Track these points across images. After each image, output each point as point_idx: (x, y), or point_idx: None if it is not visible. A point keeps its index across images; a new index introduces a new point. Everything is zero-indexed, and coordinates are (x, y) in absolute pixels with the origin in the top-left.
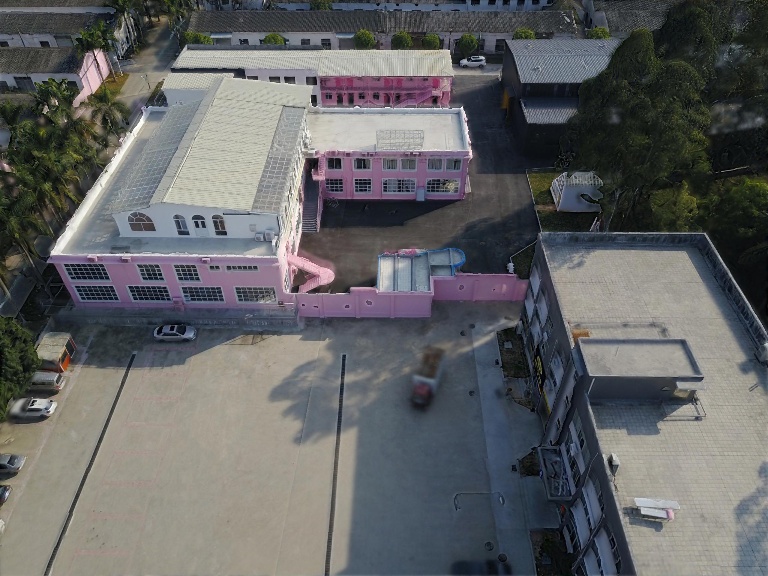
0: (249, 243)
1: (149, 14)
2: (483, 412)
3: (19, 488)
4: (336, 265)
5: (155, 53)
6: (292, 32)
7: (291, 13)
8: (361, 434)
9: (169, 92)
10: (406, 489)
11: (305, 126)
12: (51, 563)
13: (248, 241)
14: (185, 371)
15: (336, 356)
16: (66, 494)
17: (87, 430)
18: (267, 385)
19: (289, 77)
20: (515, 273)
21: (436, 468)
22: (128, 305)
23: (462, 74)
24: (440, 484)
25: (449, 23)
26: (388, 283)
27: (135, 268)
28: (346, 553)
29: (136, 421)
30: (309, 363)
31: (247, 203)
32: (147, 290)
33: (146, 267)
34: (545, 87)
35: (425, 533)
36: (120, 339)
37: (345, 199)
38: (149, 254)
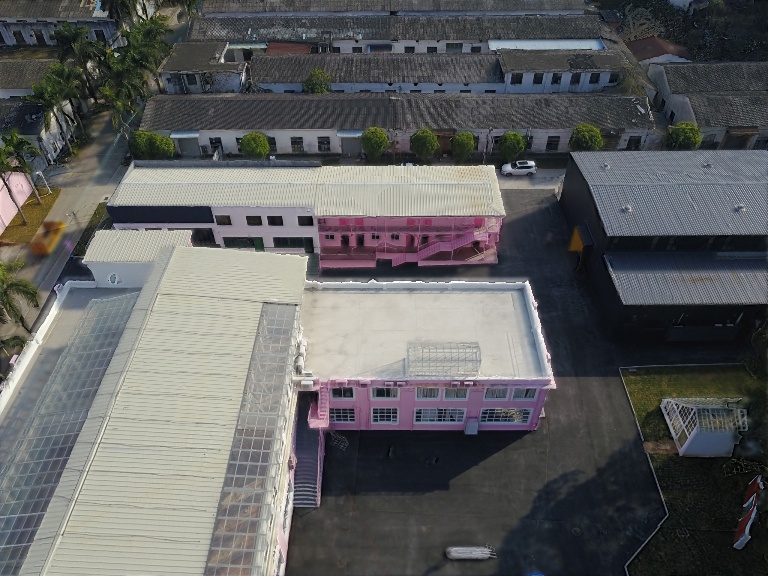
0: None
1: (94, 96)
2: None
3: None
4: None
5: (99, 154)
6: (279, 129)
7: (277, 101)
8: None
9: (94, 265)
10: None
11: (297, 331)
12: None
13: None
14: None
15: None
16: None
17: None
18: None
19: (274, 216)
20: None
21: None
22: None
23: (506, 187)
24: None
25: (486, 115)
26: None
27: None
28: None
29: None
30: None
31: (195, 566)
32: None
33: None
34: (640, 240)
35: None
36: None
37: (358, 430)
38: None
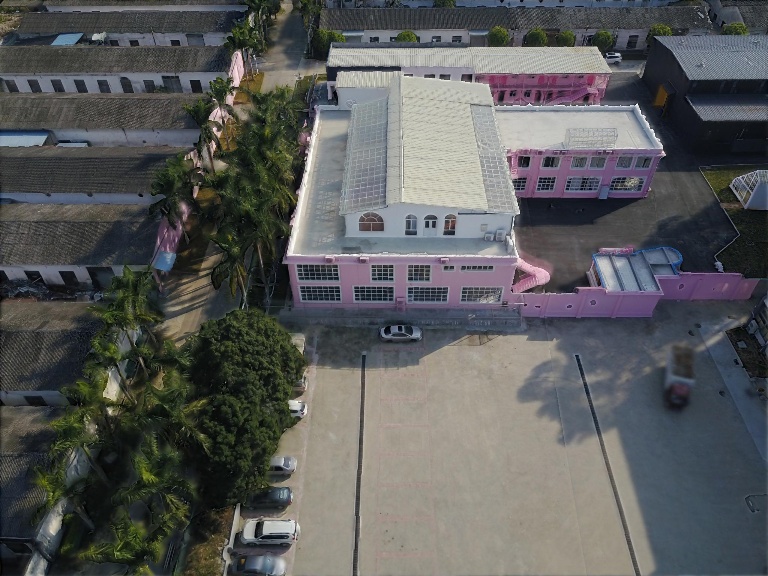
0: (479, 243)
1: (269, 12)
2: (741, 413)
3: (297, 490)
4: (540, 264)
5: (283, 51)
6: (424, 29)
7: (421, 10)
8: (623, 435)
9: (343, 91)
10: (689, 491)
11: None
12: (356, 566)
13: (477, 241)
14: (422, 372)
15: (569, 356)
16: (346, 496)
17: (344, 432)
18: (511, 386)
19: (445, 75)
20: (725, 272)
21: (713, 469)
22: (348, 305)
23: None
24: (723, 486)
25: (582, 19)
26: (613, 283)
27: (368, 268)
28: (651, 555)
29: (390, 422)
30: (545, 363)
31: (482, 203)
32: (372, 290)
33: (379, 267)
34: (712, 84)
35: (725, 535)
36: (345, 340)
37: (525, 198)
38: (387, 254)
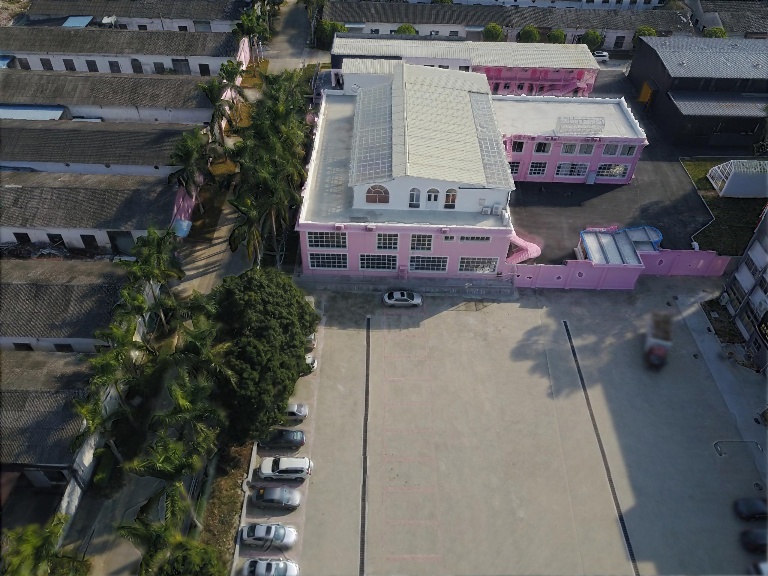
0: (477, 216)
1: (273, 3)
2: (712, 373)
3: (309, 434)
4: (532, 241)
5: (286, 40)
6: (423, 24)
7: (420, 5)
8: (606, 391)
9: (348, 76)
10: (665, 438)
11: None
12: (364, 498)
13: (475, 214)
14: (423, 333)
15: (558, 322)
16: (354, 439)
17: (351, 384)
18: (504, 347)
19: (443, 66)
20: None
21: (686, 420)
22: (353, 273)
23: None
24: (695, 434)
25: (572, 19)
26: (599, 256)
27: (375, 237)
28: (630, 492)
29: (394, 377)
30: (535, 328)
31: (481, 178)
32: (377, 259)
33: (384, 236)
34: (692, 81)
35: (696, 475)
36: (350, 304)
37: (518, 181)
38: (392, 224)
